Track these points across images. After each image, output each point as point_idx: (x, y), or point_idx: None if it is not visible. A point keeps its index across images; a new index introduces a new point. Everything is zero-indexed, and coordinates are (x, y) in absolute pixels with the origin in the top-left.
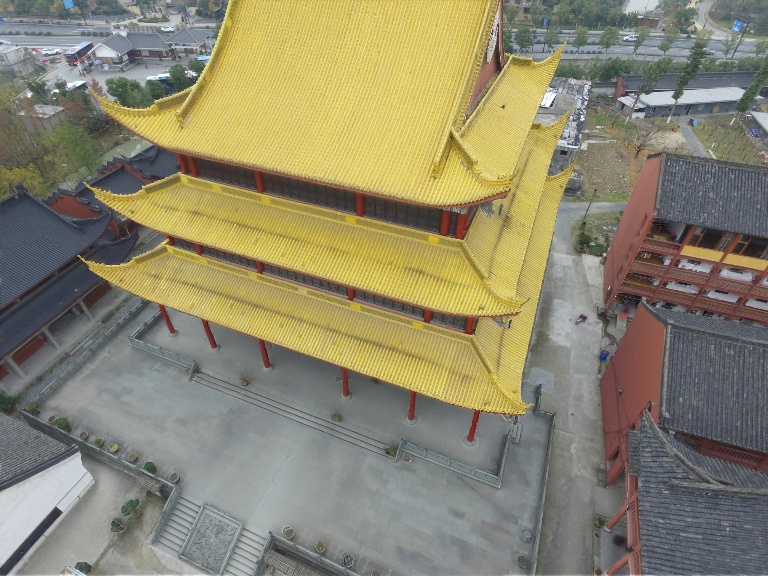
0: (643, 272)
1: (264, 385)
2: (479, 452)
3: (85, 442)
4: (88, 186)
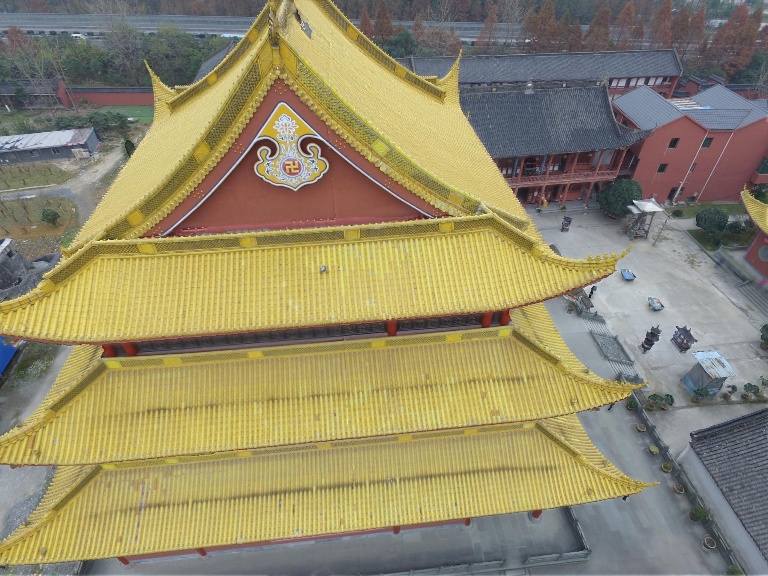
0: None
1: None
2: None
3: (680, 469)
4: (641, 385)
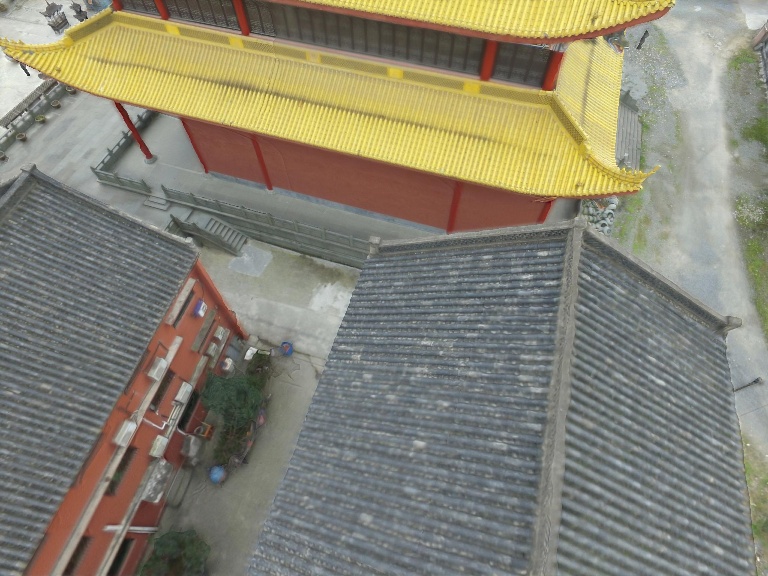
0: None
1: None
2: (137, 166)
3: None
4: None
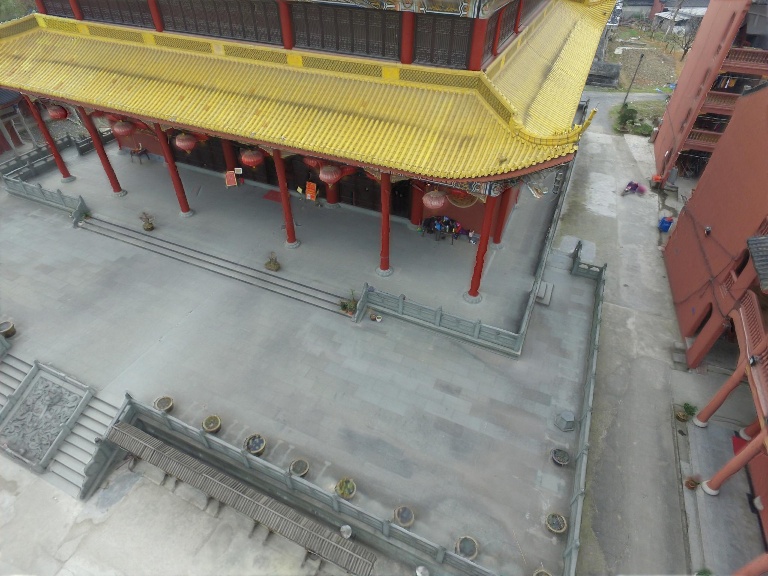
0: (722, 110)
1: (176, 231)
2: (487, 310)
3: None
4: None
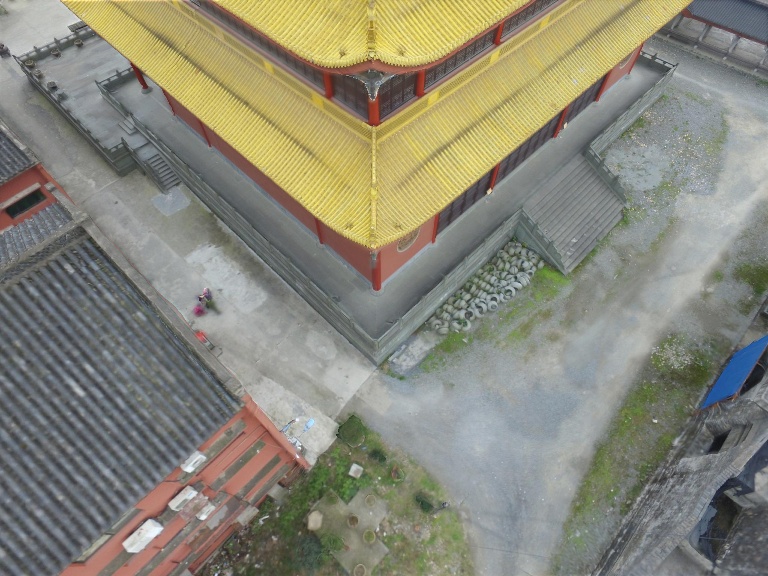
0: None
1: None
2: (134, 92)
3: None
4: None
